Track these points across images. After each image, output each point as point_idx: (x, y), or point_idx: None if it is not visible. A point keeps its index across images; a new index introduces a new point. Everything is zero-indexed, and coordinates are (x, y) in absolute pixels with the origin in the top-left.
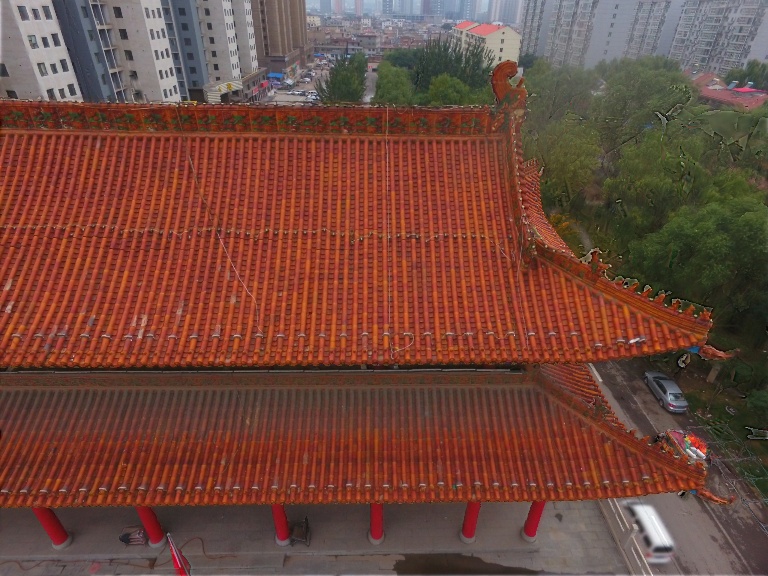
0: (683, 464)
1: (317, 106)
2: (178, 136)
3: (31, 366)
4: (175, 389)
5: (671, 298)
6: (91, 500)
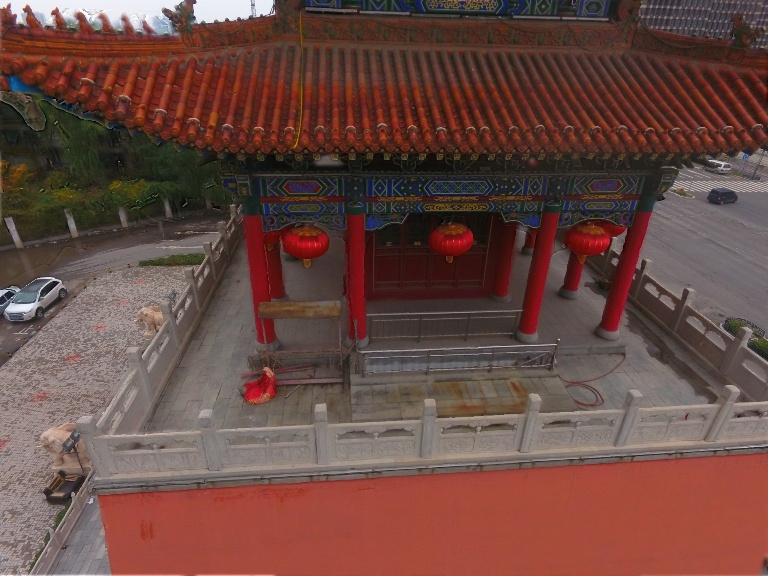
0: None
1: None
2: None
3: None
4: None
5: None
6: None
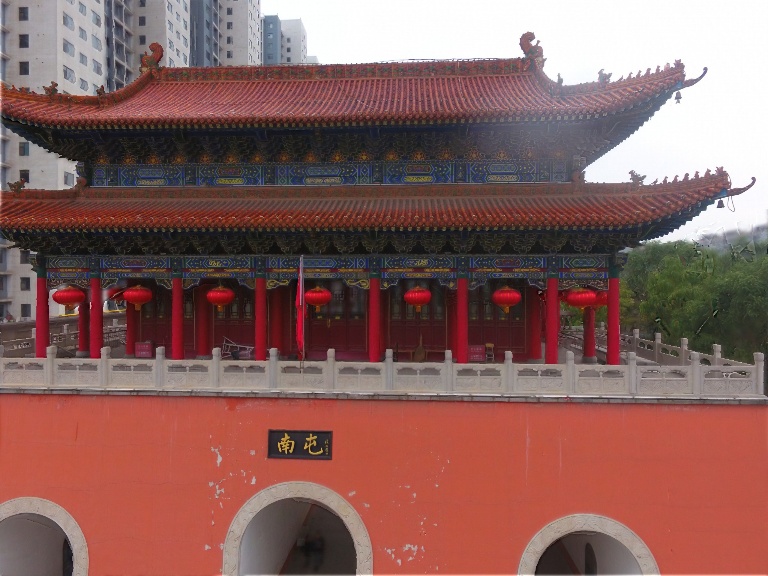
0: (708, 177)
1: (416, 62)
2: (333, 80)
3: (245, 124)
4: (312, 200)
5: (729, 351)
6: (254, 221)
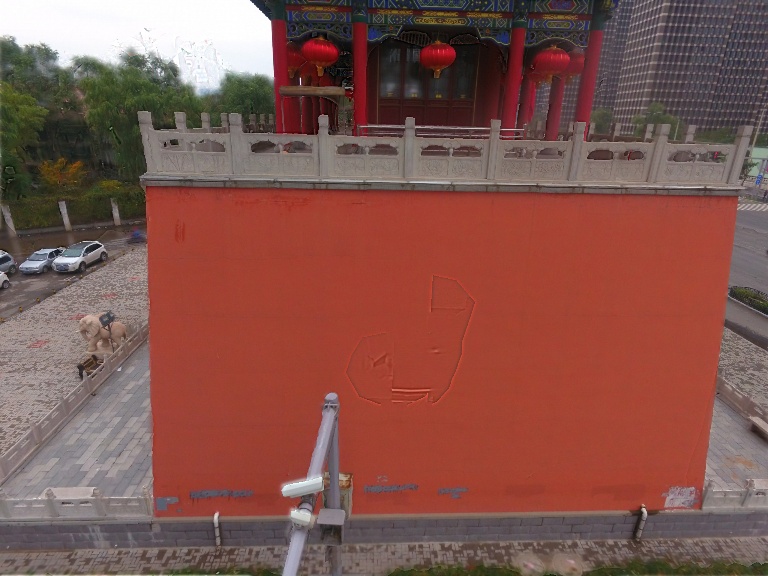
0: None
1: None
2: None
3: None
4: None
5: None
6: None
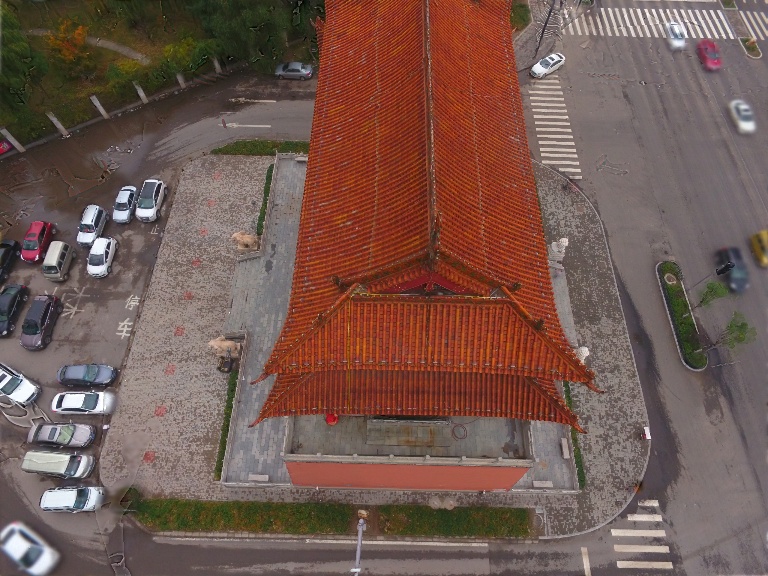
0: None
1: None
2: None
3: None
4: None
5: None
6: None
